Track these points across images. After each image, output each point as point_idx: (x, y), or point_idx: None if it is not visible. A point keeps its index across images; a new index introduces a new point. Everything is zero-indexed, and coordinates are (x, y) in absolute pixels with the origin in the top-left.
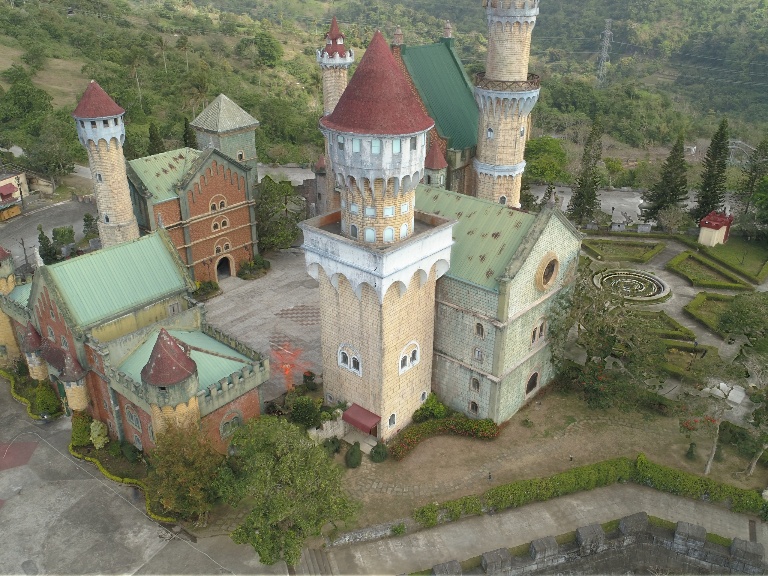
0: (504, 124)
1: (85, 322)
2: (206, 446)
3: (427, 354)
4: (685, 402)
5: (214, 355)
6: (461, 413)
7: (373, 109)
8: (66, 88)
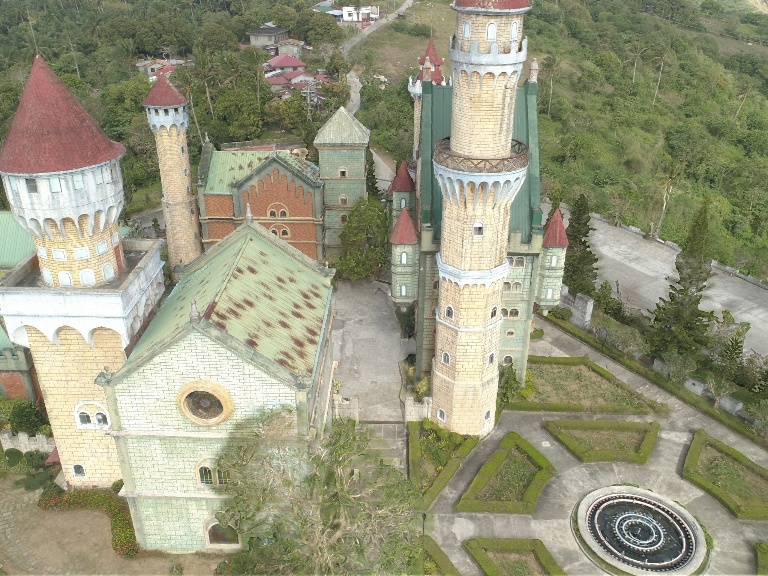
0: (449, 210)
1: None
2: None
3: None
4: None
5: (3, 327)
6: None
7: None
8: None
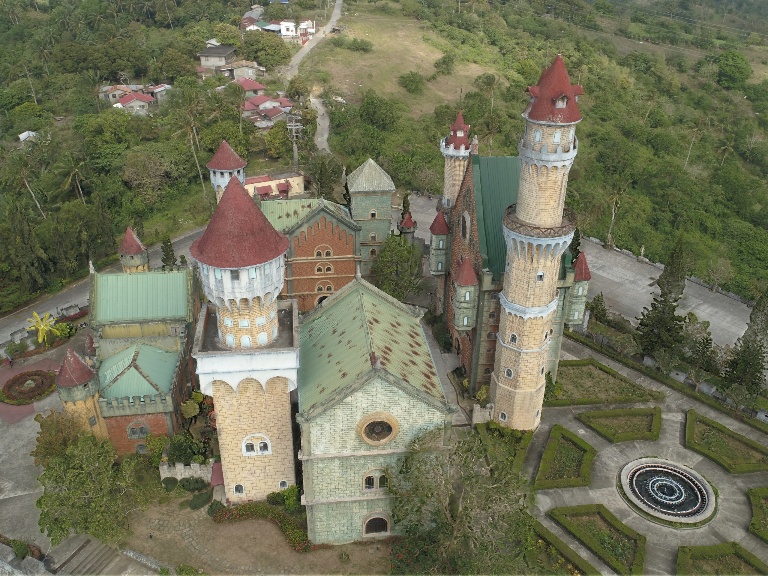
0: (517, 263)
1: (102, 319)
2: (58, 437)
3: (285, 450)
4: None
5: (144, 377)
6: (305, 515)
7: (209, 239)
8: (448, 95)
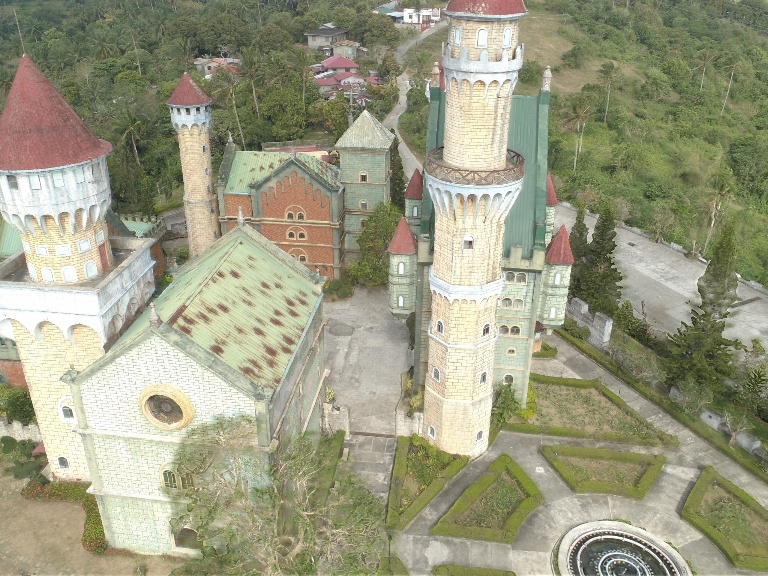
0: (440, 221)
1: (4, 253)
2: None
3: None
4: None
5: None
6: None
7: None
8: (568, 88)
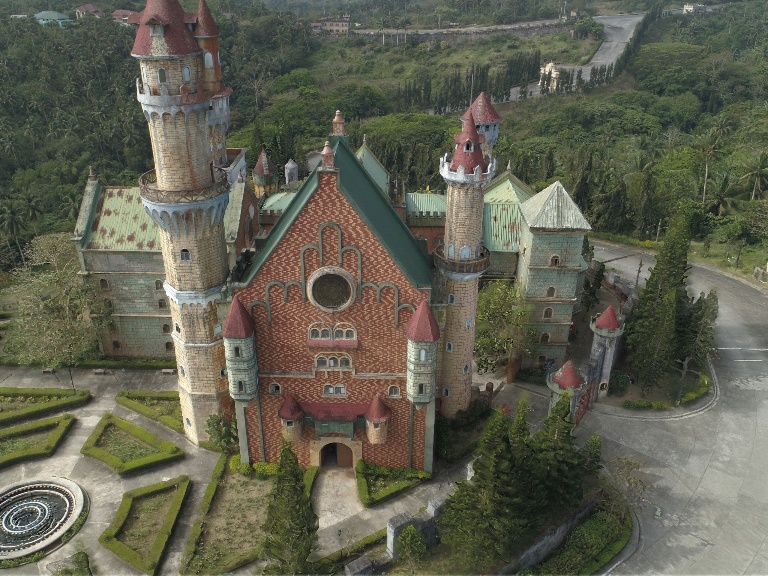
0: None
1: None
2: None
3: None
4: (4, 278)
5: None
6: None
7: None
8: None
